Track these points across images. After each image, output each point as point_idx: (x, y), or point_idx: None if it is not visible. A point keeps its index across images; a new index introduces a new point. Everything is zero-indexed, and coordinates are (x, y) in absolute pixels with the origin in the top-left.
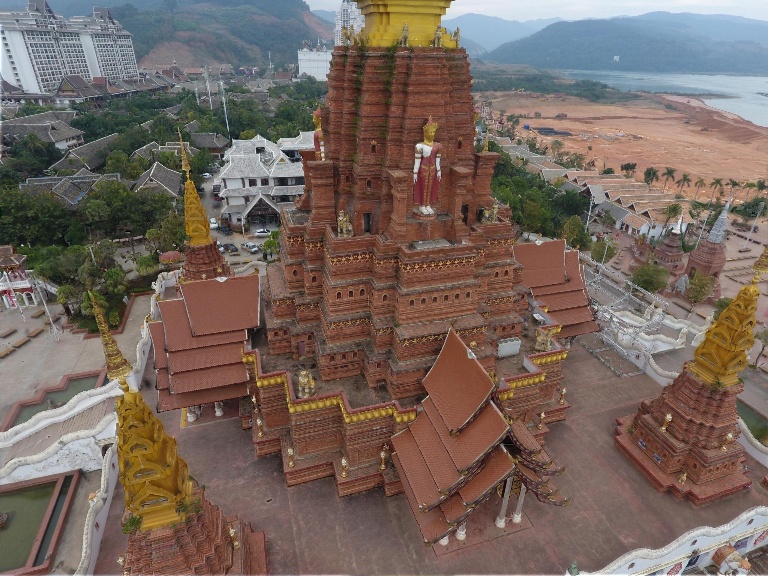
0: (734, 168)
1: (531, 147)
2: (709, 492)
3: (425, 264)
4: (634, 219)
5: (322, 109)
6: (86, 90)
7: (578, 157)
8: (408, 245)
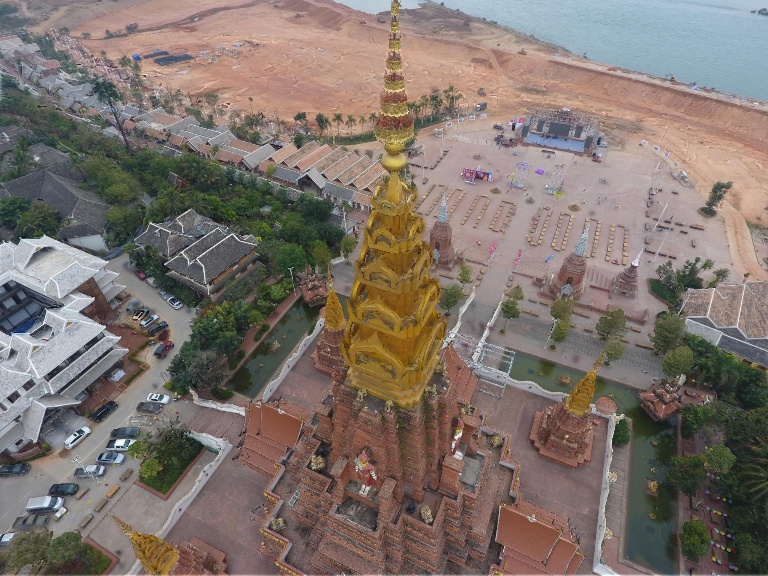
0: (351, 69)
1: (195, 115)
2: (589, 454)
3: None
4: (362, 197)
5: (366, 452)
6: None
7: (254, 120)
8: None
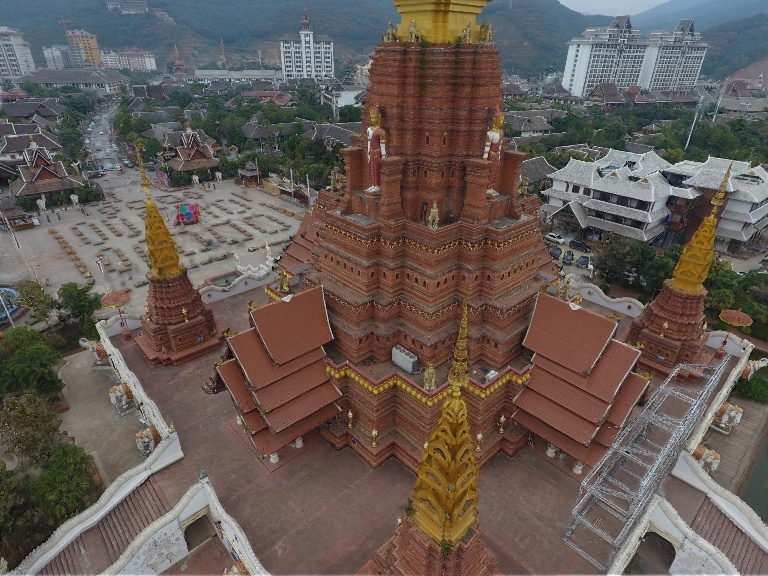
0: None
1: None
2: None
3: (334, 227)
4: None
5: None
6: (612, 96)
7: None
8: (342, 210)
